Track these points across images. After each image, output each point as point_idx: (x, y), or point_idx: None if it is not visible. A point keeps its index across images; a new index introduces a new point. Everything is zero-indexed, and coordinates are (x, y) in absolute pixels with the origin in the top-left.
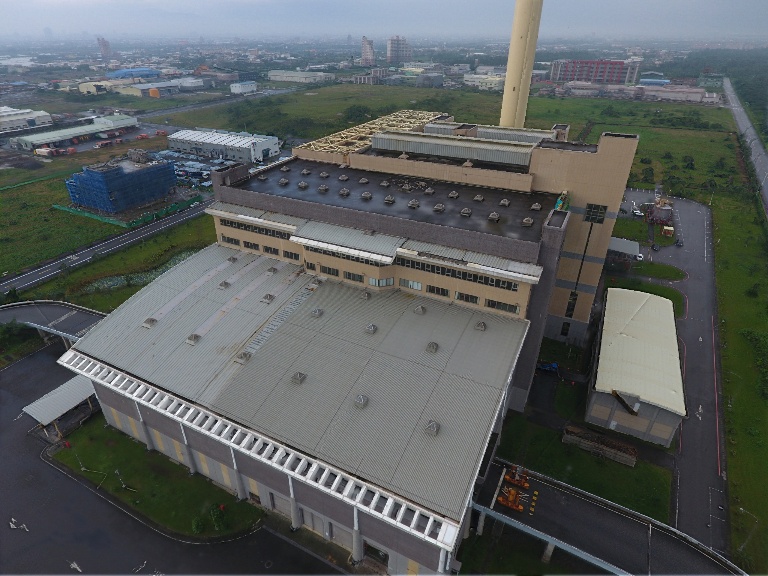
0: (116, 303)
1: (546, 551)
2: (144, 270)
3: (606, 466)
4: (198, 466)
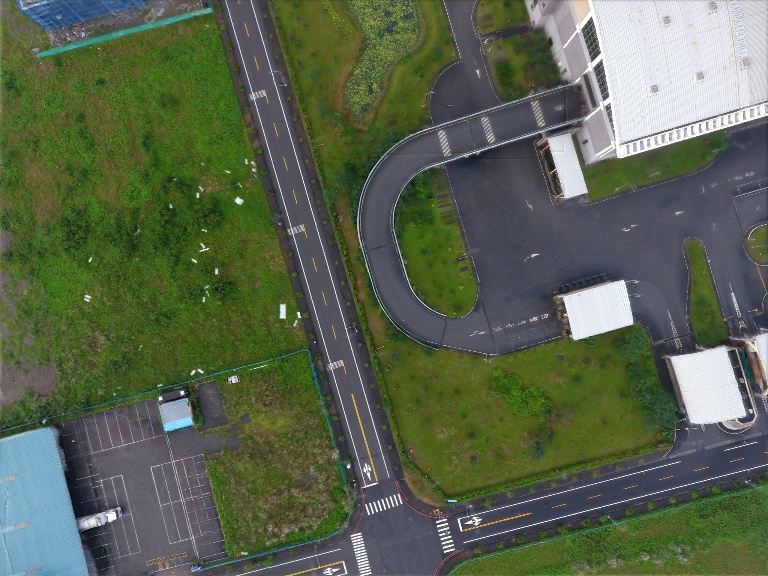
0: (418, 99)
1: None
2: (363, 49)
3: None
4: None
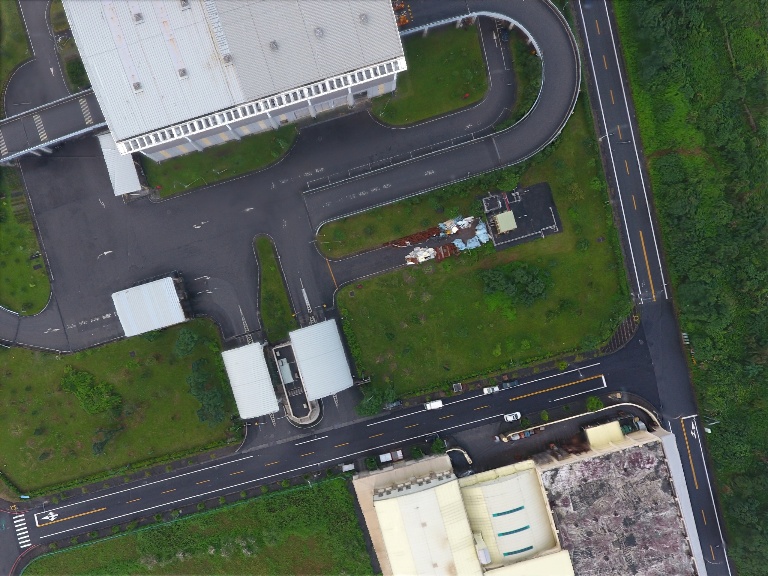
0: None
1: (424, 32)
2: None
3: None
4: (240, 134)
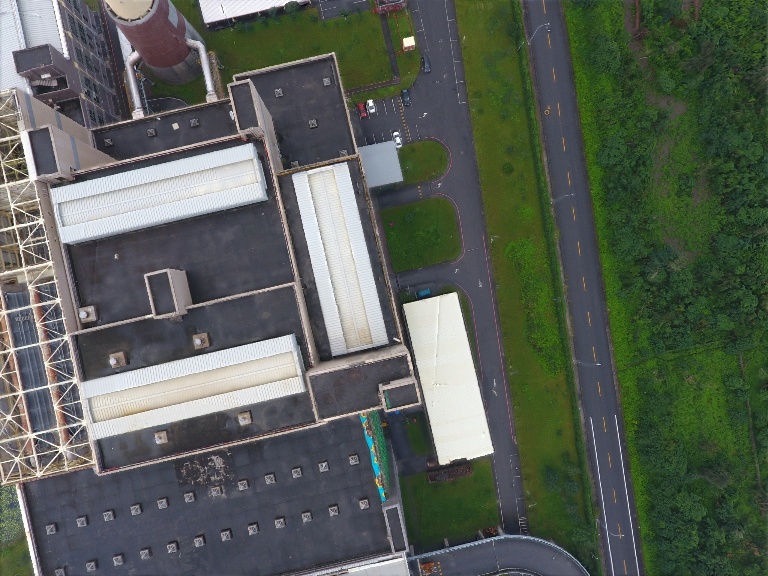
0: None
1: None
2: None
3: (458, 483)
4: None
